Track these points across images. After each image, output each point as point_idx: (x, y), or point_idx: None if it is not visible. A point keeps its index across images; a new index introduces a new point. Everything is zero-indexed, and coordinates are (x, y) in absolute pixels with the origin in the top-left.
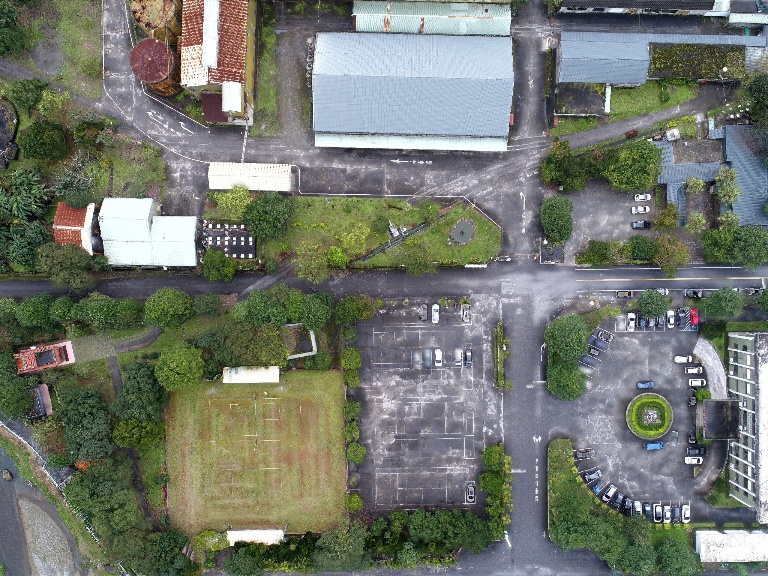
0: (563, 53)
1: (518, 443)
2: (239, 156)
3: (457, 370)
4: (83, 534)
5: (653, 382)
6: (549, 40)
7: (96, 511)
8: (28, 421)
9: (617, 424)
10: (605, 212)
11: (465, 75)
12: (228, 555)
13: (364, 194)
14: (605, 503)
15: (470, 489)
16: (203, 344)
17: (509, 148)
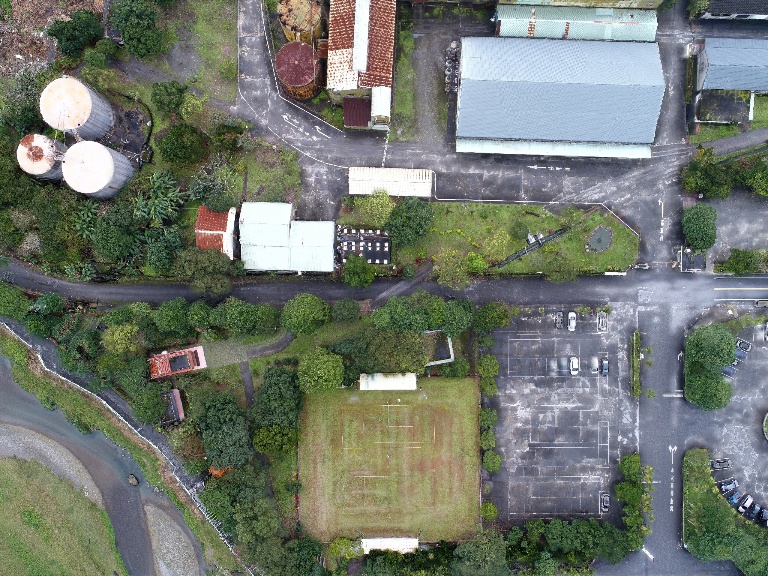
0: (709, 60)
1: (653, 452)
2: (375, 161)
3: (592, 378)
4: (212, 540)
5: None
6: (690, 46)
7: (240, 518)
8: (161, 426)
9: (754, 434)
10: (745, 220)
11: (615, 81)
12: (359, 563)
13: (501, 200)
14: (741, 514)
15: (606, 499)
16: (344, 350)
17: None
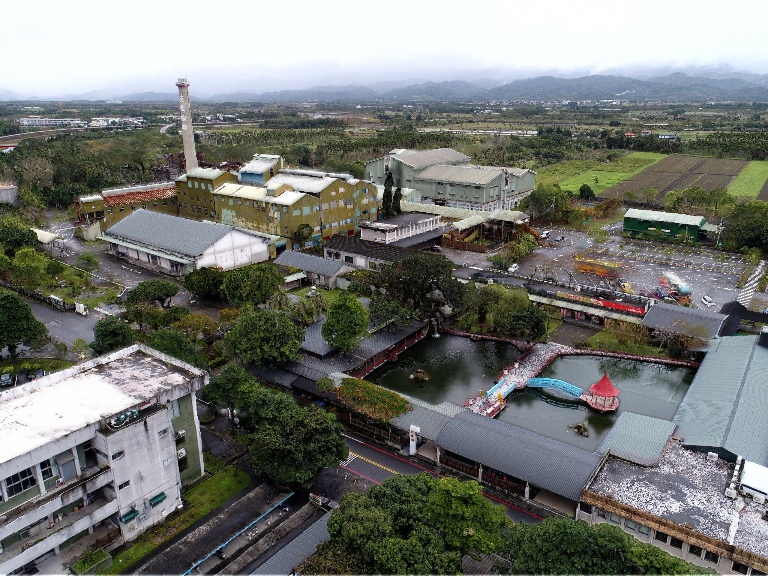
0: None
1: None
2: None
3: None
4: None
5: None
6: None
7: None
8: None
9: None
10: None
11: None
12: None
13: None
14: None
15: None
16: None
17: None
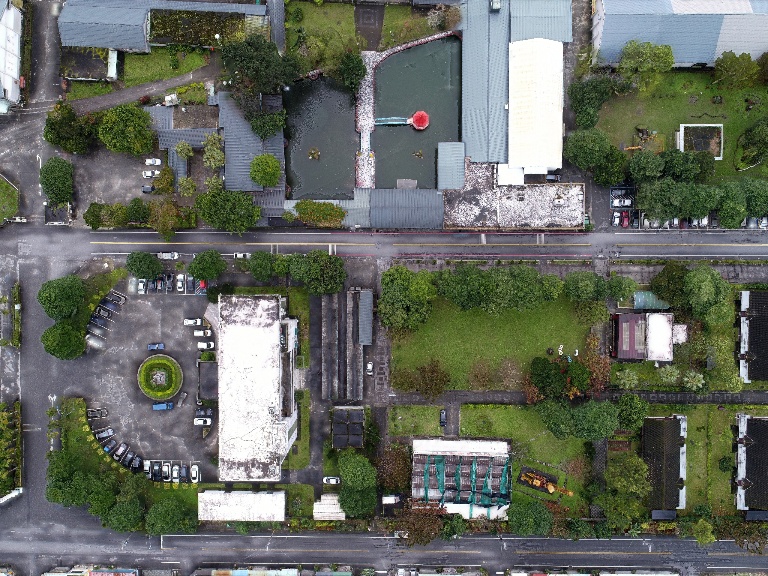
0: (60, 17)
1: (34, 401)
2: None
3: None
4: None
5: (164, 344)
6: None
7: None
8: None
9: (130, 385)
10: (118, 176)
11: None
12: None
13: None
14: (118, 462)
15: None
16: None
17: (26, 111)
